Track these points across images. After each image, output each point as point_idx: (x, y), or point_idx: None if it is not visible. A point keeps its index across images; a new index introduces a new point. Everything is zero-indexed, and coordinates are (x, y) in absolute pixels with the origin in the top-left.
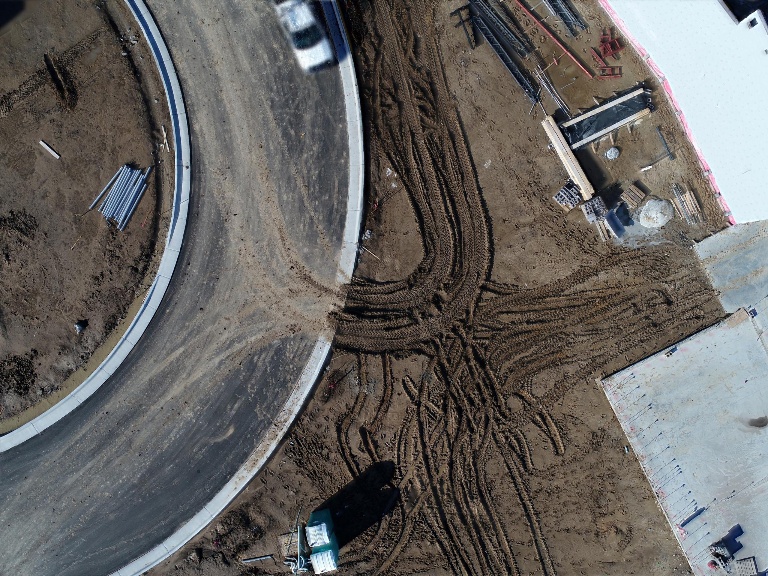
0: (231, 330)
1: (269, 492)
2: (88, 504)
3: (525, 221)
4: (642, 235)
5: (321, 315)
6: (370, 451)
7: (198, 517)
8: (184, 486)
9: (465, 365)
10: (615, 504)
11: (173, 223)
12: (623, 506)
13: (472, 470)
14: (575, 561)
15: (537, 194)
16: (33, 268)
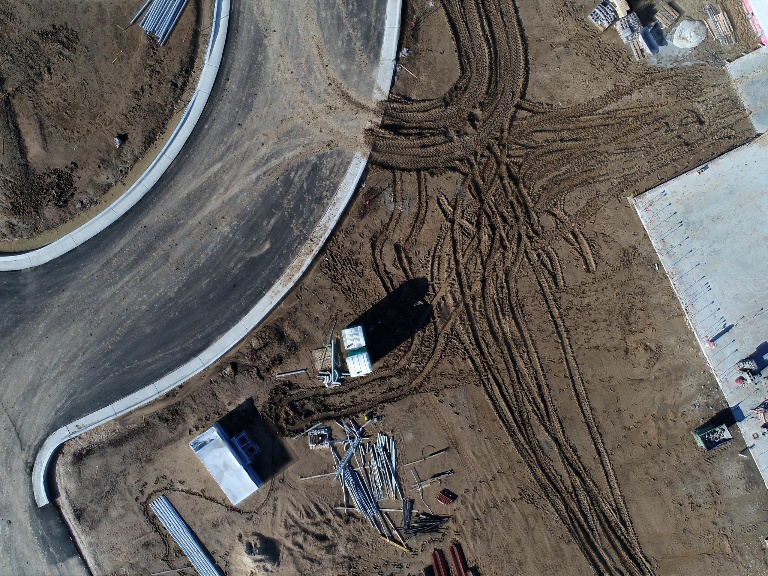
0: (269, 146)
1: (304, 307)
2: (125, 317)
3: (560, 41)
4: (675, 55)
5: (358, 132)
6: (404, 268)
7: (234, 331)
8: (220, 300)
9: (499, 183)
10: (645, 322)
11: (213, 38)
12: (653, 324)
13: (504, 287)
14: (605, 378)
15: (572, 14)
16: (74, 81)
